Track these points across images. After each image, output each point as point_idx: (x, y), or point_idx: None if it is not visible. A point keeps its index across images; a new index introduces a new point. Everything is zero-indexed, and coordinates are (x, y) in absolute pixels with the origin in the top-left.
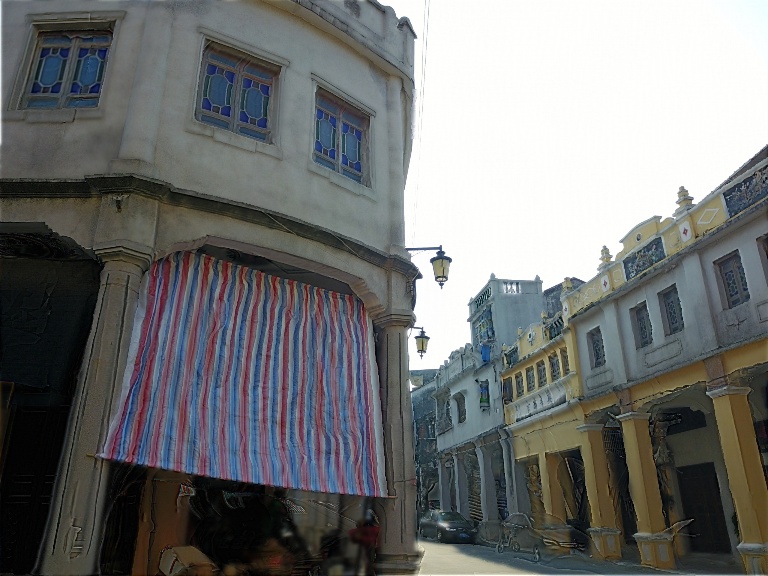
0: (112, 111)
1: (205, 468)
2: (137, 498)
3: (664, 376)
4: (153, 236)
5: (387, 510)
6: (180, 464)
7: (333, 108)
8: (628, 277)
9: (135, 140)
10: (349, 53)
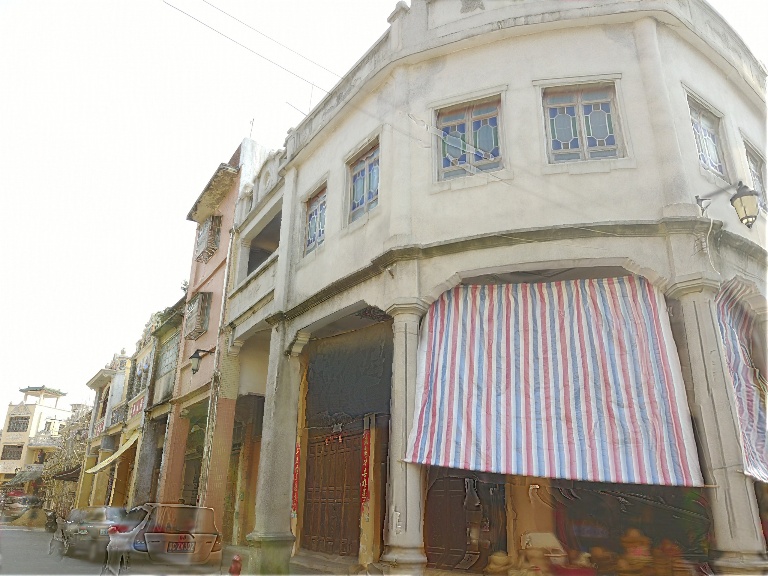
0: (384, 204)
1: (487, 465)
2: (504, 491)
3: None
4: (417, 288)
5: (708, 501)
6: (464, 463)
7: (568, 98)
8: None
9: (394, 220)
10: (574, 34)
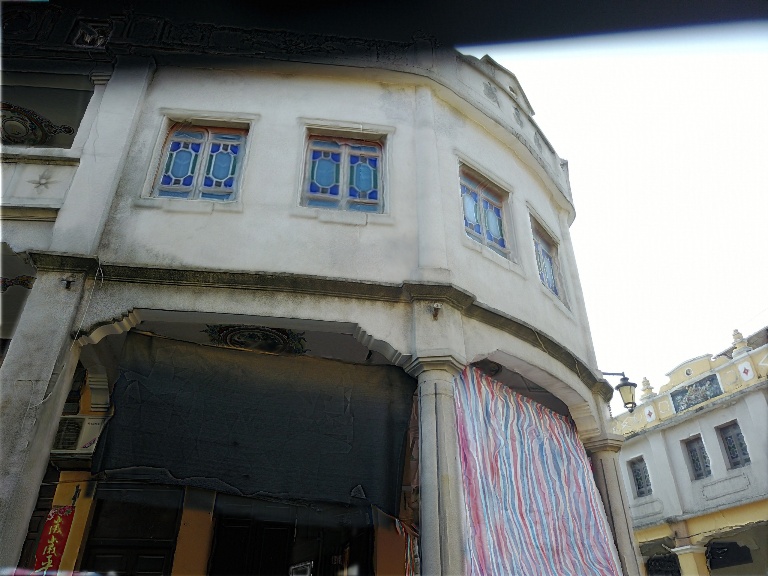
0: (402, 219)
1: None
2: None
3: (731, 510)
4: (464, 347)
5: None
6: None
7: (535, 234)
8: (677, 409)
9: (437, 250)
10: (540, 186)
